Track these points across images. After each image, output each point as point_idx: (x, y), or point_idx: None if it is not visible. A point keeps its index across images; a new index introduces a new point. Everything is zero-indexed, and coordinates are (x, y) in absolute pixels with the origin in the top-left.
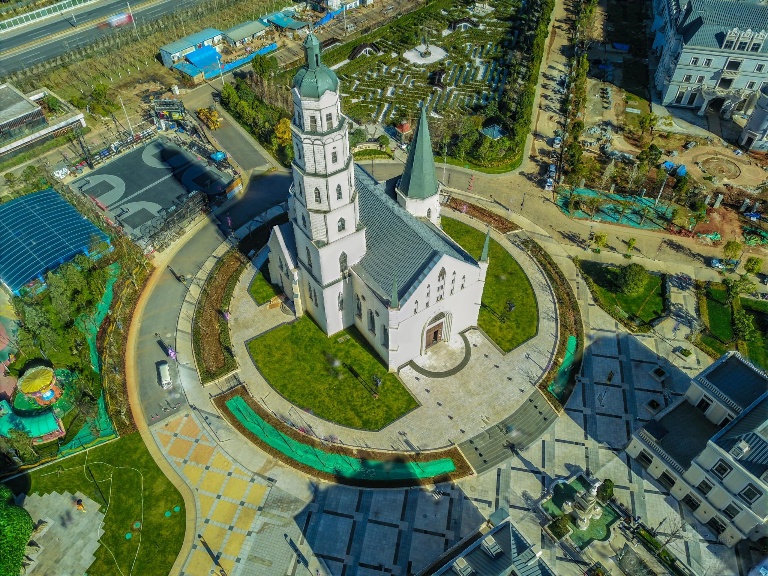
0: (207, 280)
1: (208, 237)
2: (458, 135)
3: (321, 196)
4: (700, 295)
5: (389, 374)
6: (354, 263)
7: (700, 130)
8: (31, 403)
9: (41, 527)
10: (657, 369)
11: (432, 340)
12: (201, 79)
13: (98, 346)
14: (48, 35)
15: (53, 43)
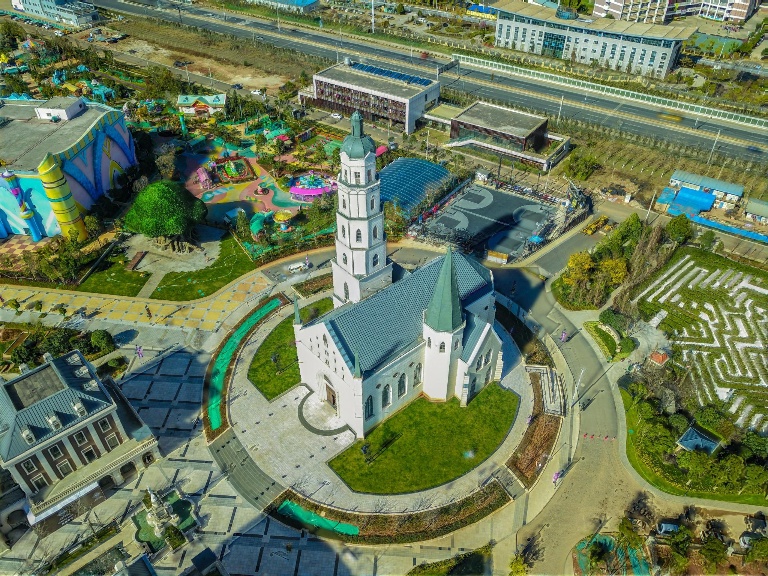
0: None
1: None
2: (691, 417)
3: None
4: None
5: (300, 379)
6: (353, 301)
7: None
8: (278, 224)
9: (199, 249)
10: None
11: (333, 401)
12: (663, 209)
13: None
14: (667, 122)
15: (661, 128)
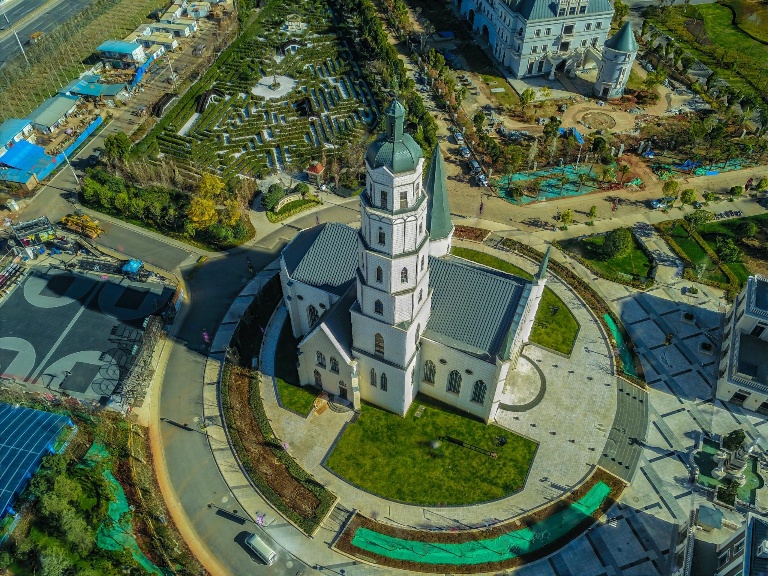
0: (224, 414)
1: (184, 364)
2: None
3: (409, 275)
4: (665, 236)
5: (489, 426)
6: (423, 330)
7: (561, 92)
8: None
9: None
10: (686, 314)
11: None
12: (34, 183)
13: (150, 557)
14: None
15: None
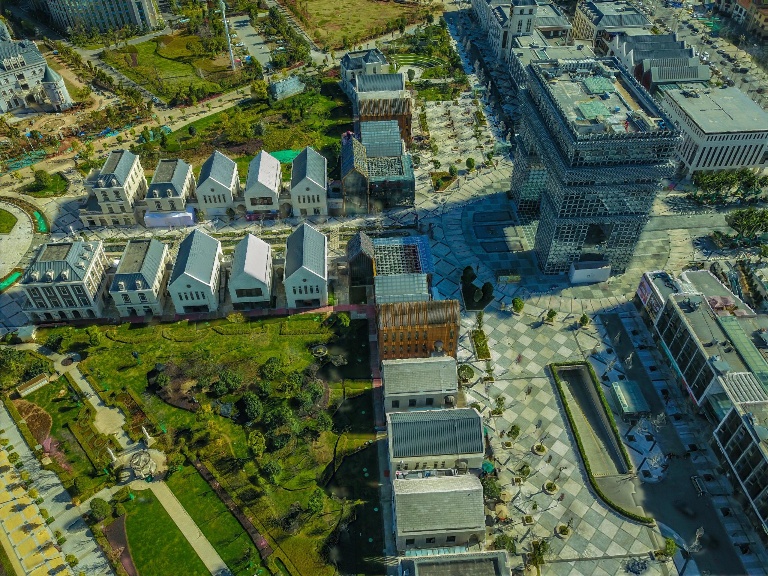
0: None
1: None
2: None
3: None
4: (78, 170)
5: None
6: None
7: (32, 114)
8: None
9: None
10: (78, 200)
11: None
12: None
13: None
14: None
15: None
